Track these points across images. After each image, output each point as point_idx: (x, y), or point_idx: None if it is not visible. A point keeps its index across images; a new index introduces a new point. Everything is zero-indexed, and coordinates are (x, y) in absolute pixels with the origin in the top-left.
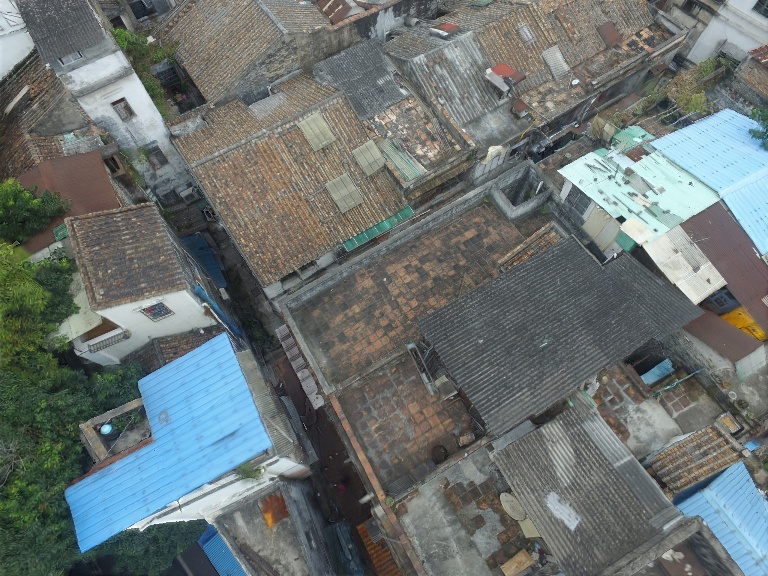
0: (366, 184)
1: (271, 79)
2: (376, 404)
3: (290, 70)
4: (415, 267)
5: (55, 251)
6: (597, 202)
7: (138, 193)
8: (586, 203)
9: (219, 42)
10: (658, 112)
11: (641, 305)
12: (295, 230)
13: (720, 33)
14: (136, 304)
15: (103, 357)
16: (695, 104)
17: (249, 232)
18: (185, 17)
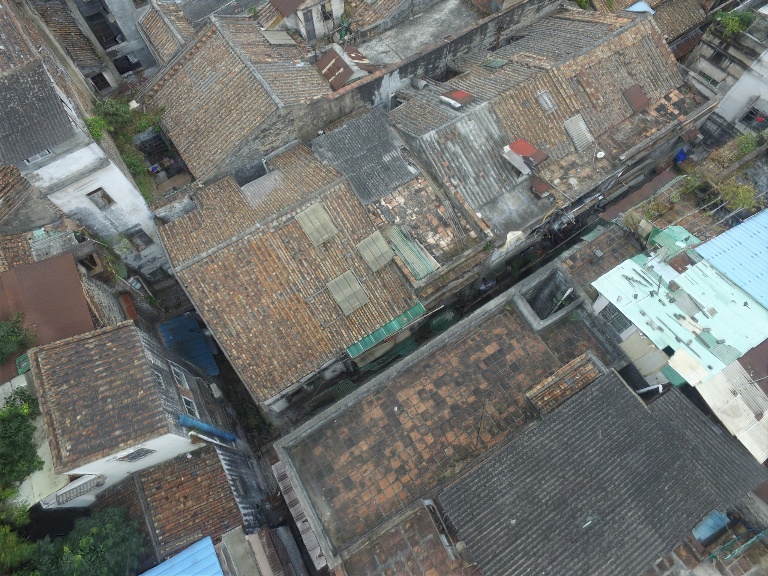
0: (372, 280)
1: (266, 152)
2: (388, 570)
3: (287, 141)
4: (430, 392)
5: (16, 391)
6: (639, 328)
7: (119, 287)
8: (625, 324)
9: (208, 112)
10: (696, 196)
11: (696, 461)
12: (293, 337)
13: (752, 89)
14: (109, 456)
15: (75, 501)
16: (743, 199)
17: (241, 342)
18: (171, 81)
